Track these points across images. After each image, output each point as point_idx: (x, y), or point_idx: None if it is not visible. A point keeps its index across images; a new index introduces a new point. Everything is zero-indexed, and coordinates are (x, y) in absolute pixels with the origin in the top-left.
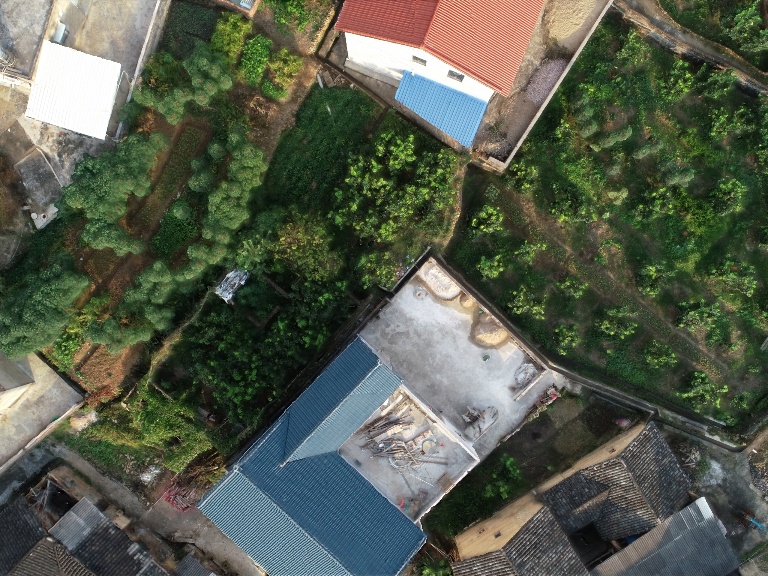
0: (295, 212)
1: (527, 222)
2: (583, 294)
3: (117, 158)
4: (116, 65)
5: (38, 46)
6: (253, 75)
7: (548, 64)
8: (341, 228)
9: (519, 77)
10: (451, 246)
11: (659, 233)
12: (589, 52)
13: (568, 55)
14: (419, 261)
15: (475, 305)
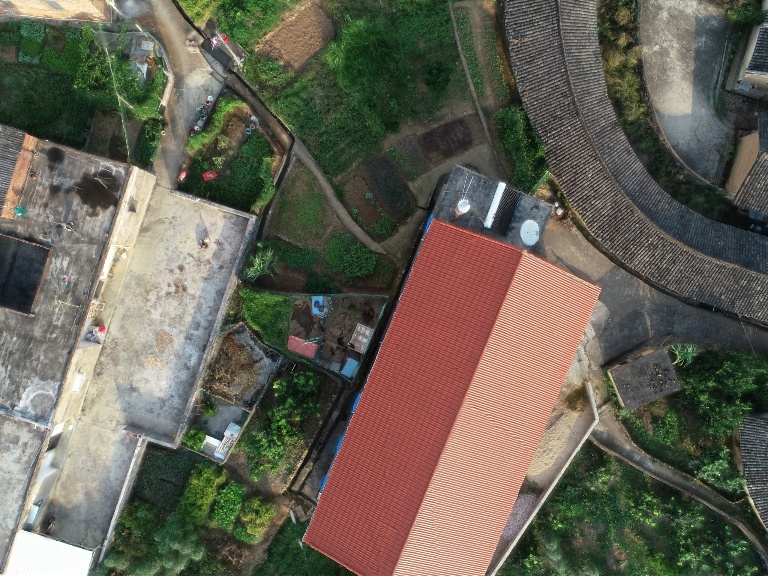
0: None
1: None
2: None
3: None
4: (87, 553)
5: (10, 541)
6: (226, 522)
7: (518, 499)
8: None
9: None
10: None
11: None
12: None
13: (538, 490)
14: None
15: None
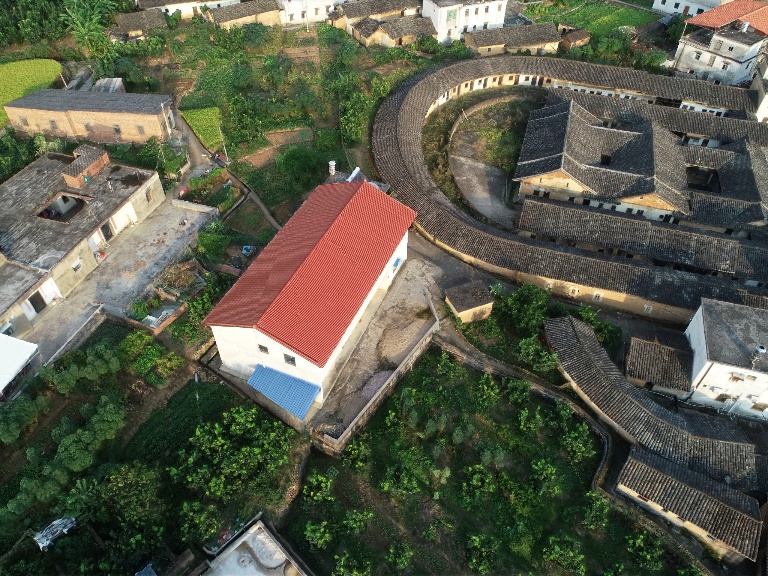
0: (136, 462)
1: (362, 501)
2: (416, 574)
3: (1, 410)
4: (34, 346)
5: None
6: (142, 368)
7: (380, 373)
8: (176, 481)
9: (357, 381)
10: (288, 521)
11: (490, 516)
12: (418, 372)
13: (396, 368)
14: (248, 525)
15: (299, 575)
